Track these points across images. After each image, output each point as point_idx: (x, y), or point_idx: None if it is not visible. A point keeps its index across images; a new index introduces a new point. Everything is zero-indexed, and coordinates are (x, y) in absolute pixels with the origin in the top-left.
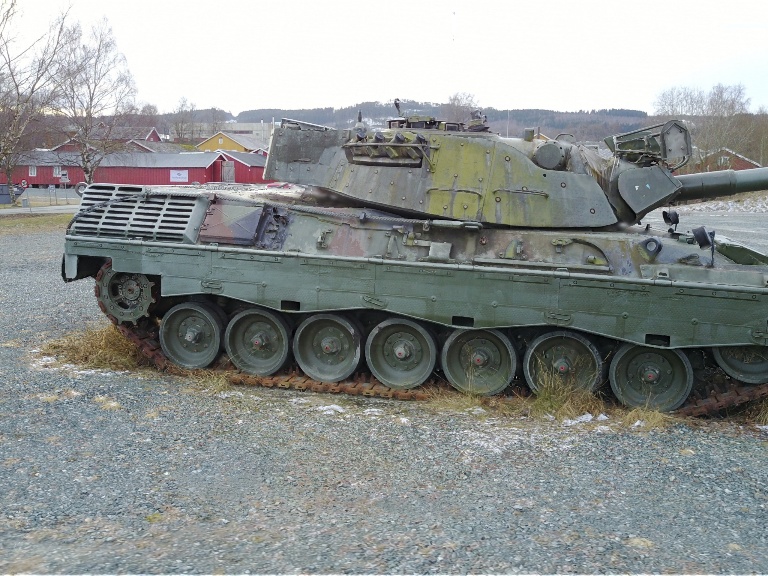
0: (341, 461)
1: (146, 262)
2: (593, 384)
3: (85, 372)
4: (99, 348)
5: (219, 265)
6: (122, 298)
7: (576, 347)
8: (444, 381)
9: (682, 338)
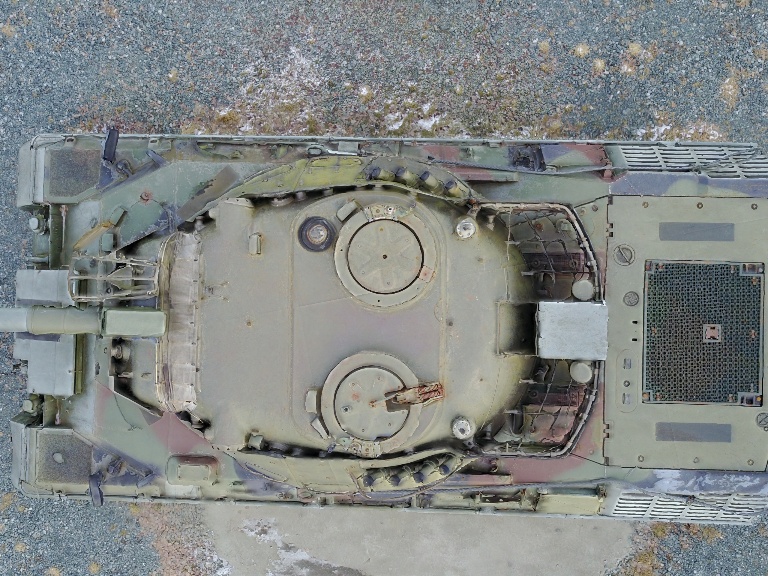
0: (386, 1)
1: None
2: None
3: (660, 128)
4: None
5: None
6: None
7: None
8: None
9: None
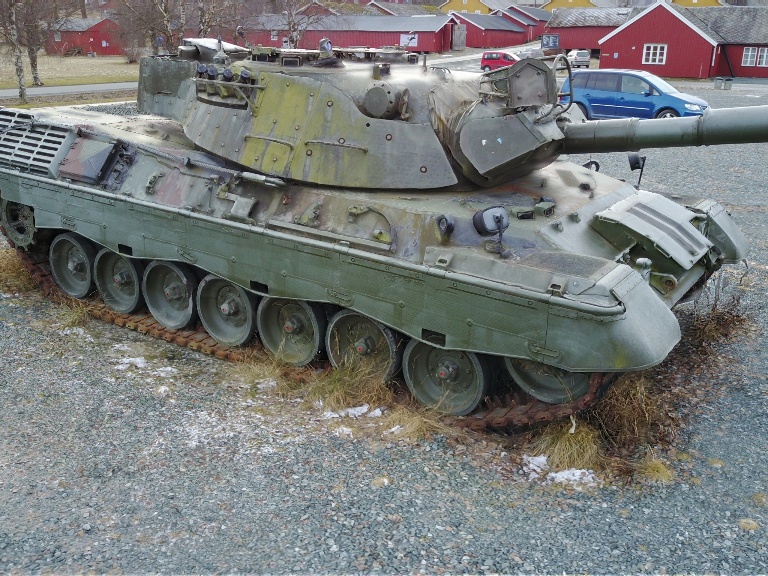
0: (30, 434)
1: (22, 193)
2: (387, 372)
3: None
4: (3, 269)
5: (71, 202)
6: (21, 223)
7: None
8: (260, 344)
9: (457, 339)
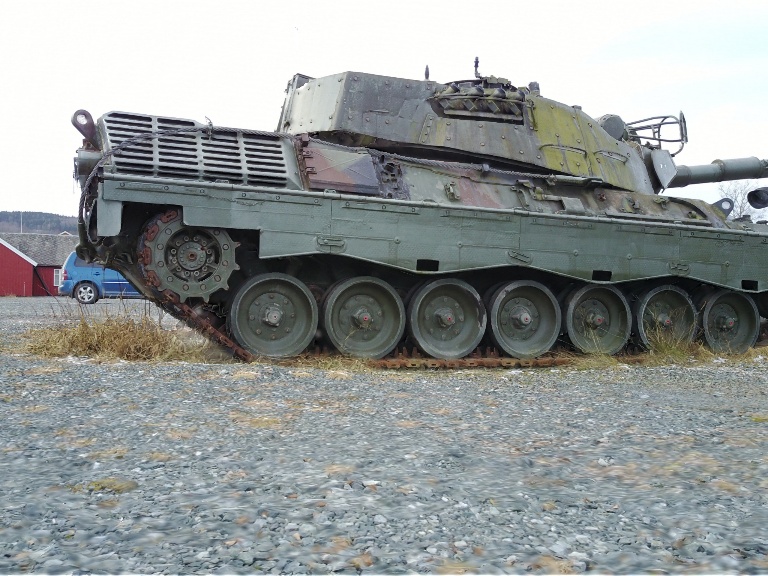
0: None
1: (238, 212)
2: (693, 334)
3: None
4: None
5: (341, 217)
6: (176, 268)
7: (670, 302)
8: (569, 345)
9: (766, 282)
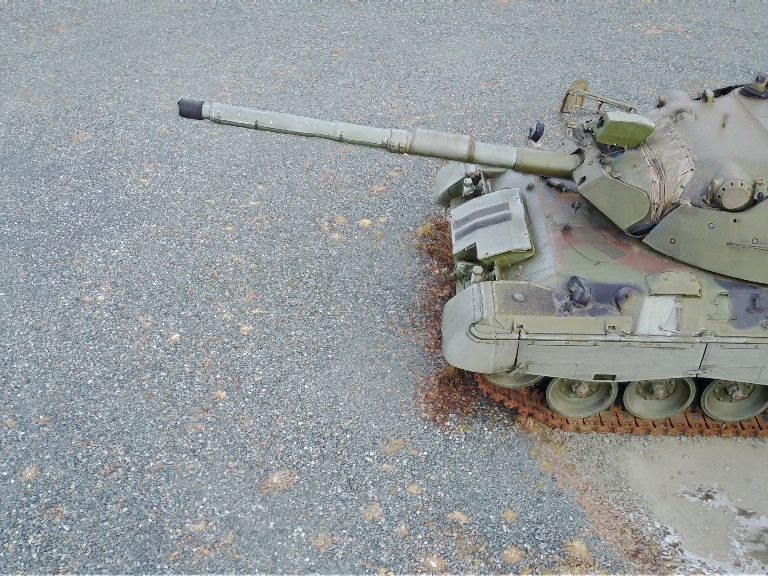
0: None
1: None
2: None
3: None
4: None
5: None
6: None
7: None
8: None
9: None
